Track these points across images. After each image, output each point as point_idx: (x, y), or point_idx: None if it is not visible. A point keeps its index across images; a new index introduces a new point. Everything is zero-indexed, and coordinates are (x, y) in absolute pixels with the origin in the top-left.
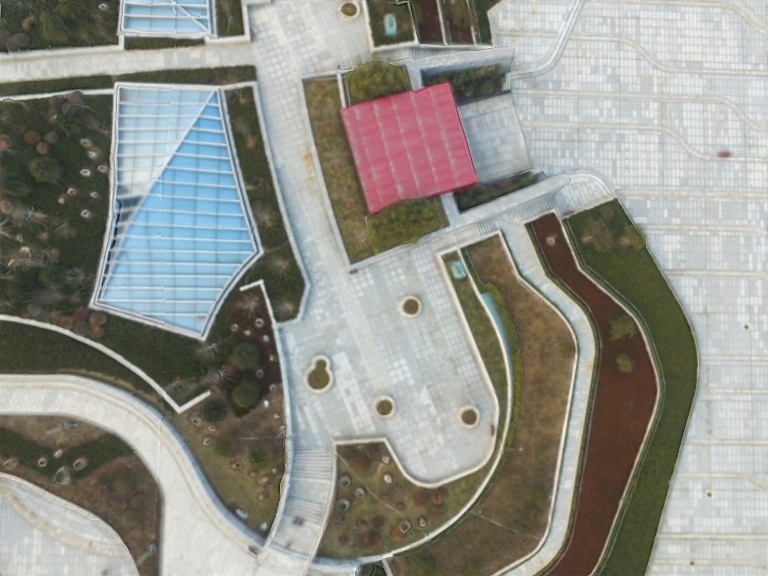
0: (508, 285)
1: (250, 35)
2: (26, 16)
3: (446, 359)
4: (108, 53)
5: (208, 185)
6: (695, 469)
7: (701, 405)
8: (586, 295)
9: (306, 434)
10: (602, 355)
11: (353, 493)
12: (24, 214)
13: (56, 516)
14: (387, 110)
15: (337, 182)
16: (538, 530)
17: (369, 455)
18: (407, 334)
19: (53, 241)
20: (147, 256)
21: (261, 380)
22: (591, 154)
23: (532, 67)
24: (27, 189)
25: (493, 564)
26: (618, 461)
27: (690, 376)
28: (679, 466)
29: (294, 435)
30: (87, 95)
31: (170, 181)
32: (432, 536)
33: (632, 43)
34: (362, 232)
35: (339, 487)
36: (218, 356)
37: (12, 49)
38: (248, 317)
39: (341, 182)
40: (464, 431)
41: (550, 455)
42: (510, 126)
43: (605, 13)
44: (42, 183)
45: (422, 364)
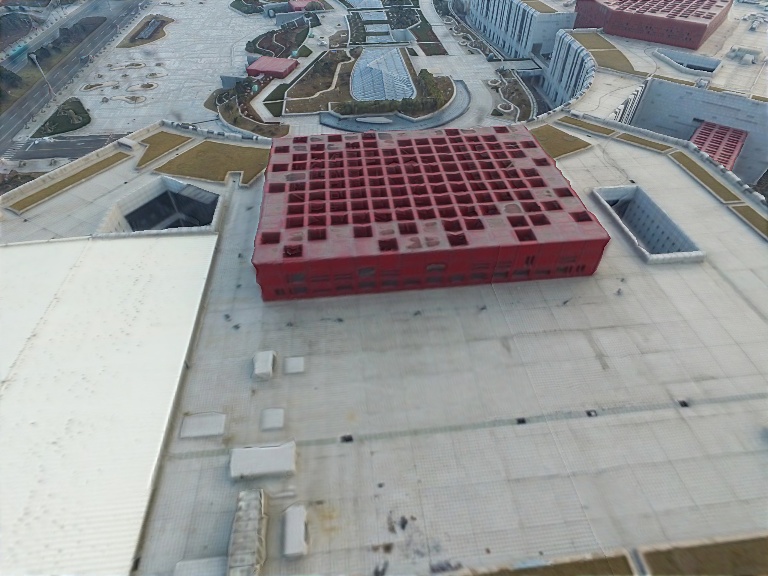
0: None
1: None
2: None
3: None
4: None
5: (356, 0)
6: None
7: None
8: (259, 4)
9: None
10: (257, 0)
11: None
12: None
13: None
14: None
15: None
16: None
17: None
18: None
19: None
20: None
21: None
22: None
23: None
24: None
25: None
26: None
27: None
28: None
29: None
30: None
31: None
32: None
33: None
34: None
35: None
36: None
37: None
38: None
39: None
40: None
41: None
42: None
43: (243, 33)
44: None
45: None
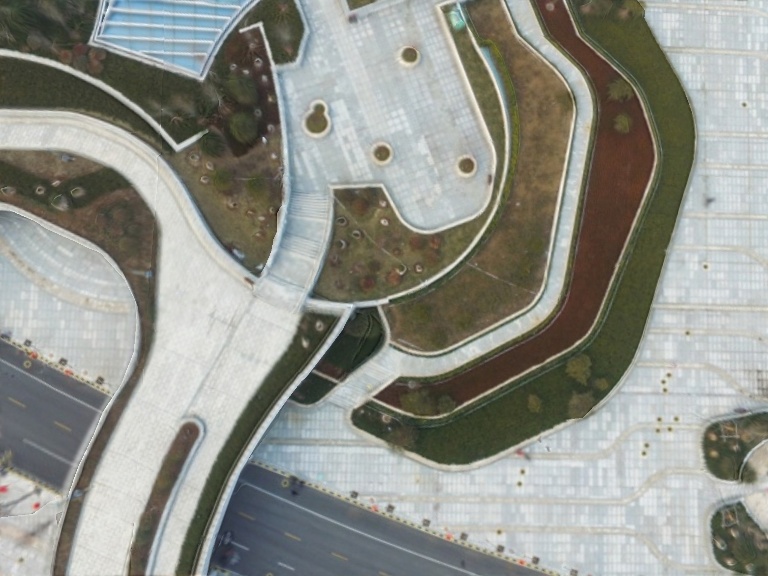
0: (507, 42)
1: None
2: None
3: (444, 110)
4: None
5: None
6: (691, 242)
7: (698, 179)
8: (585, 60)
9: (303, 179)
10: (600, 119)
11: (350, 235)
12: None
13: (53, 272)
14: None
15: None
16: (534, 284)
17: (366, 197)
18: (405, 85)
19: None
20: None
21: (259, 119)
22: None
23: None
24: None
25: (489, 317)
26: (615, 224)
27: (687, 147)
28: (676, 238)
29: (291, 178)
30: None
31: None
32: (428, 283)
33: None
34: None
35: (336, 226)
36: (216, 79)
37: None
38: (247, 57)
39: None
40: (461, 181)
41: (547, 211)
42: None
43: None
44: None
45: (420, 115)
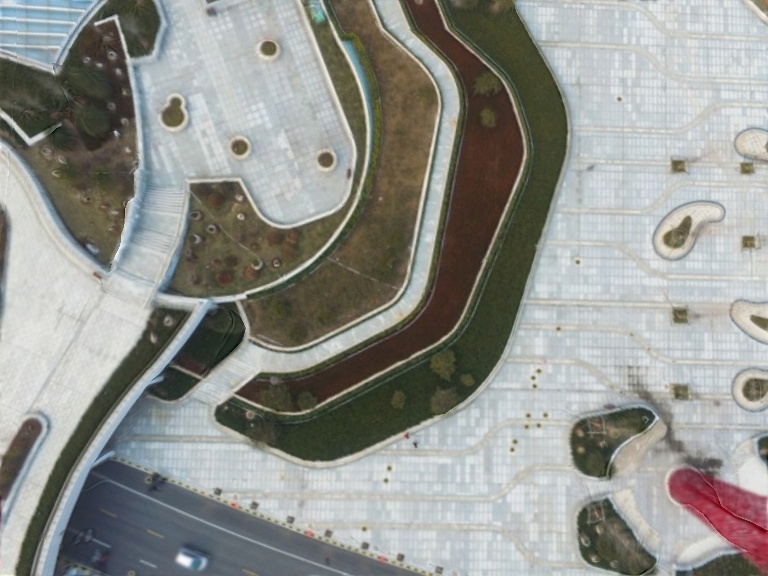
0: (371, 36)
1: None
2: None
3: (305, 104)
4: None
5: None
6: (564, 237)
7: (572, 174)
8: (453, 54)
9: (160, 173)
10: (467, 113)
11: (205, 229)
12: None
13: None
14: None
15: None
16: (396, 279)
17: (221, 191)
18: (266, 78)
19: None
20: None
21: (112, 112)
22: None
23: None
24: None
25: (350, 312)
26: (482, 218)
27: (559, 142)
28: (548, 234)
29: (147, 172)
30: None
31: None
32: (286, 278)
33: None
34: None
35: (189, 220)
36: (61, 72)
37: None
38: (101, 50)
39: None
40: (321, 175)
41: (410, 206)
42: None
43: None
44: None
45: (280, 108)
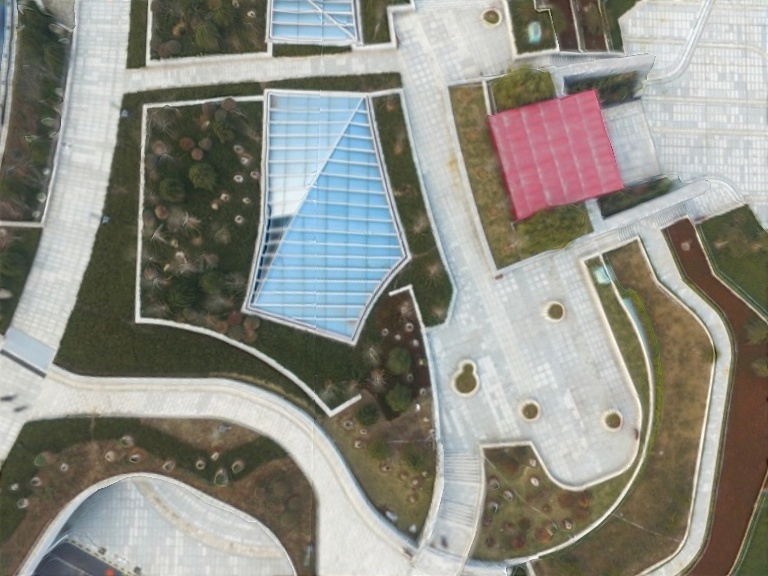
0: (647, 290)
1: (397, 42)
2: (177, 23)
3: (589, 363)
4: (257, 60)
5: (358, 191)
6: None
7: None
8: (721, 300)
9: (453, 437)
10: (737, 359)
11: (501, 496)
12: (179, 219)
13: (197, 518)
14: (535, 117)
15: (483, 188)
16: (678, 533)
17: (517, 458)
18: (550, 339)
19: (213, 246)
20: (301, 261)
21: (412, 384)
22: (719, 160)
23: (661, 74)
24: (184, 195)
25: (634, 566)
26: (753, 464)
27: None
28: None
29: (442, 438)
30: (238, 102)
31: (324, 187)
32: (577, 538)
33: (758, 50)
34: (509, 238)
35: (489, 490)
36: (378, 360)
37: (164, 56)
38: (398, 322)
39: (487, 188)
40: (607, 435)
41: (689, 458)
42: (640, 132)
43: (731, 20)
44: (199, 189)
45: (565, 368)
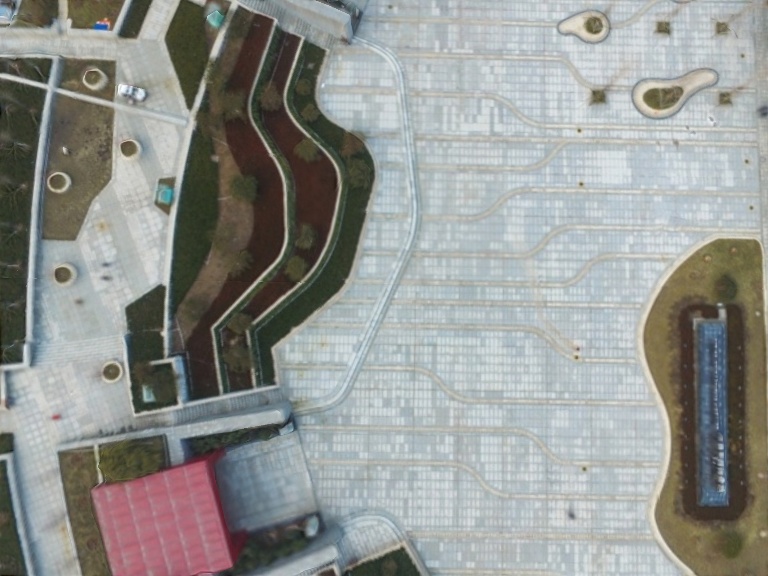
0: None
1: (6, 405)
2: None
3: None
4: None
5: None
6: None
7: None
8: None
9: None
10: None
11: None
12: None
13: None
14: (139, 491)
15: (92, 559)
16: None
17: None
18: None
19: None
20: None
21: None
22: (381, 493)
23: (320, 402)
24: None
25: None
26: None
27: None
28: None
29: None
30: None
31: None
32: None
33: (428, 372)
34: None
35: None
36: None
37: None
38: None
39: (96, 559)
40: None
41: None
42: (296, 465)
43: (400, 340)
44: None
45: None
